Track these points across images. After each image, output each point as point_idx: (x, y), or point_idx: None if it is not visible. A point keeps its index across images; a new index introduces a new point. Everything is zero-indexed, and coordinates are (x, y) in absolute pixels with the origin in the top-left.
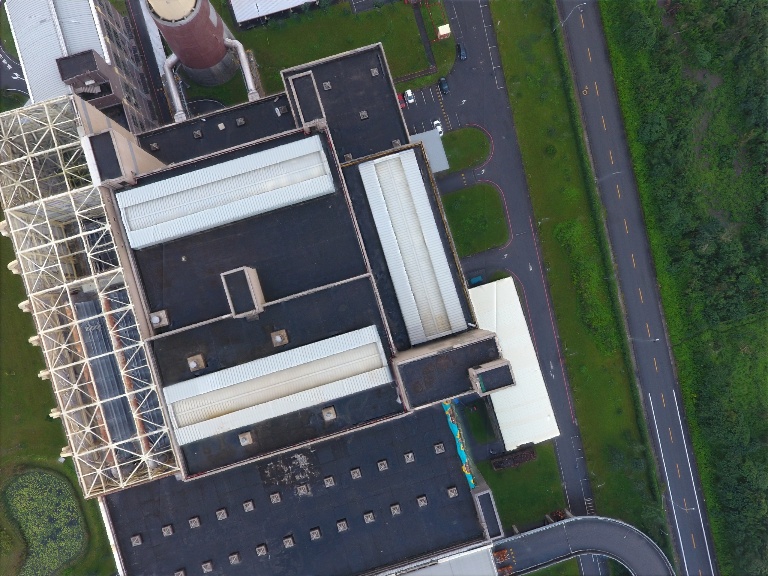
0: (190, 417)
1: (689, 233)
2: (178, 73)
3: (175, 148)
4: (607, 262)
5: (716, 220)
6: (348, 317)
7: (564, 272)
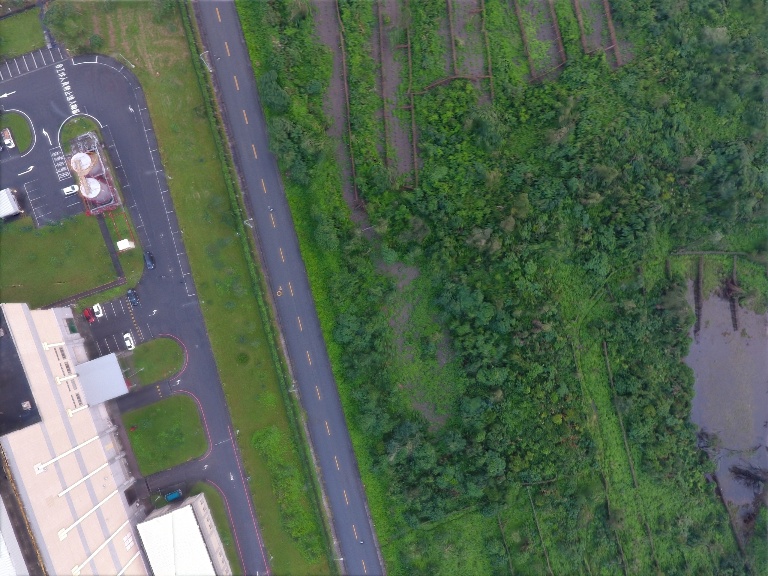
0: None
1: (389, 433)
2: None
3: None
4: (305, 470)
5: (408, 424)
6: None
7: (265, 480)
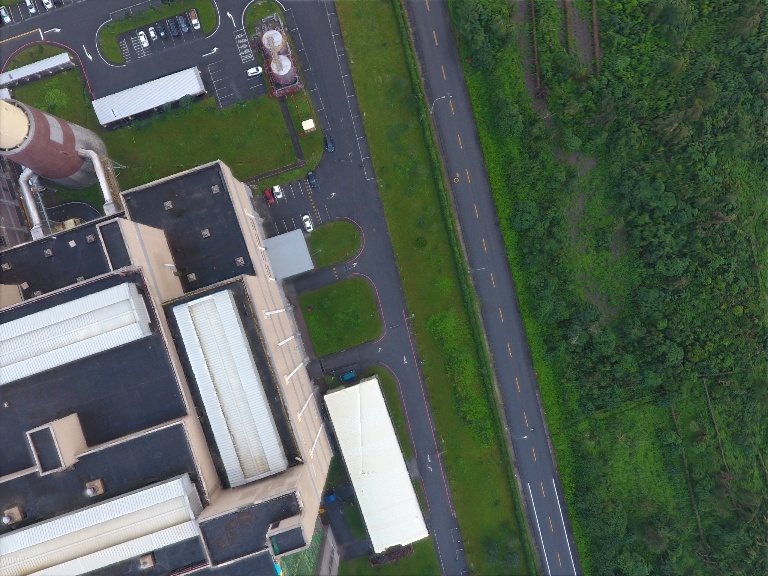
0: (3, 574)
1: (564, 321)
2: (37, 183)
3: (27, 267)
4: (480, 354)
5: (588, 310)
6: (164, 464)
7: (439, 364)
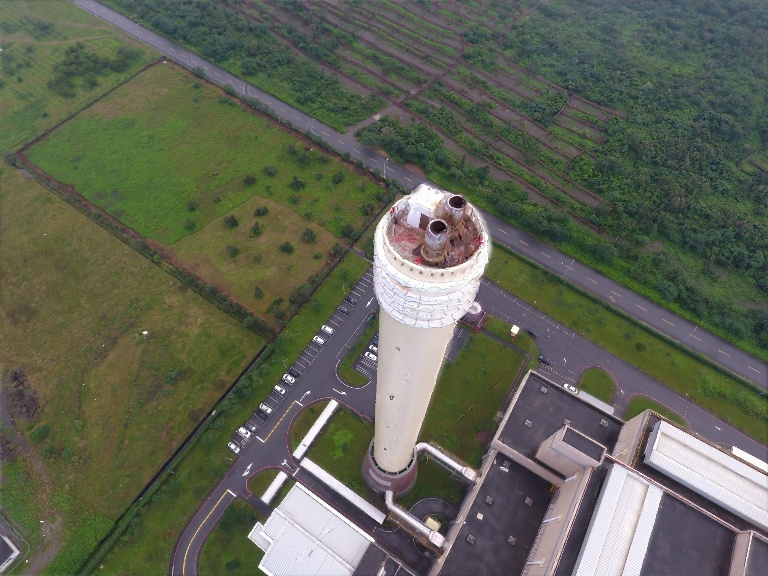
0: None
1: (755, 328)
2: None
3: (466, 567)
4: (748, 384)
5: (760, 310)
6: None
7: (736, 413)
